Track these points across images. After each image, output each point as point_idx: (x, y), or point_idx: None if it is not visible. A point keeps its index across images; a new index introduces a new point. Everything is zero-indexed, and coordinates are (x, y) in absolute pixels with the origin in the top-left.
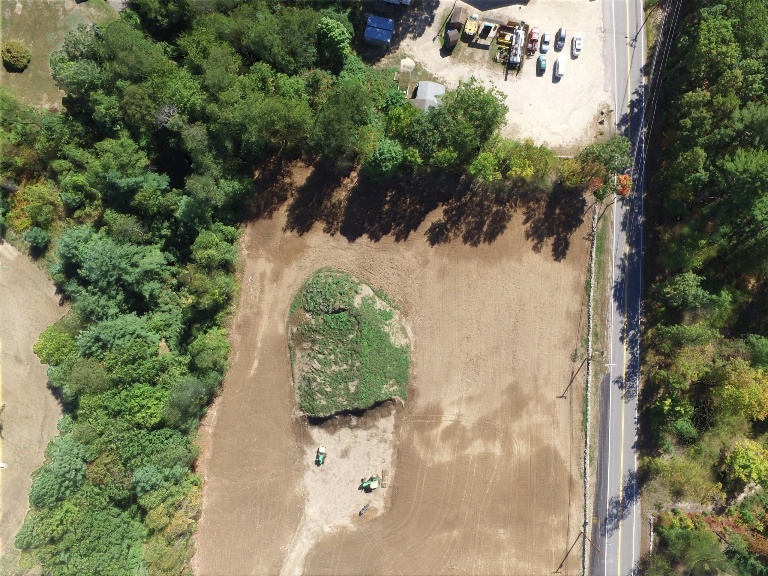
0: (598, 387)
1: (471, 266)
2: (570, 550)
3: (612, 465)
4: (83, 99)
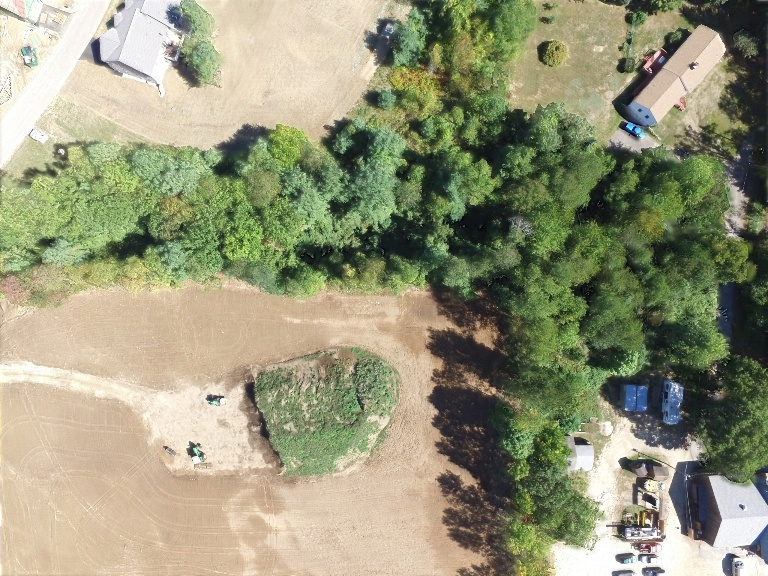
0: None
1: (423, 520)
2: None
3: None
4: (524, 134)
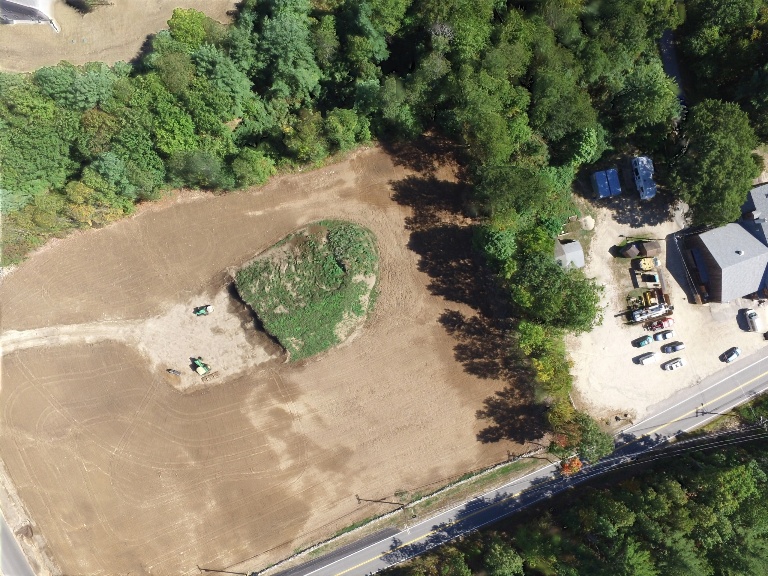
0: (383, 527)
1: (437, 364)
2: (226, 572)
3: (319, 573)
4: None
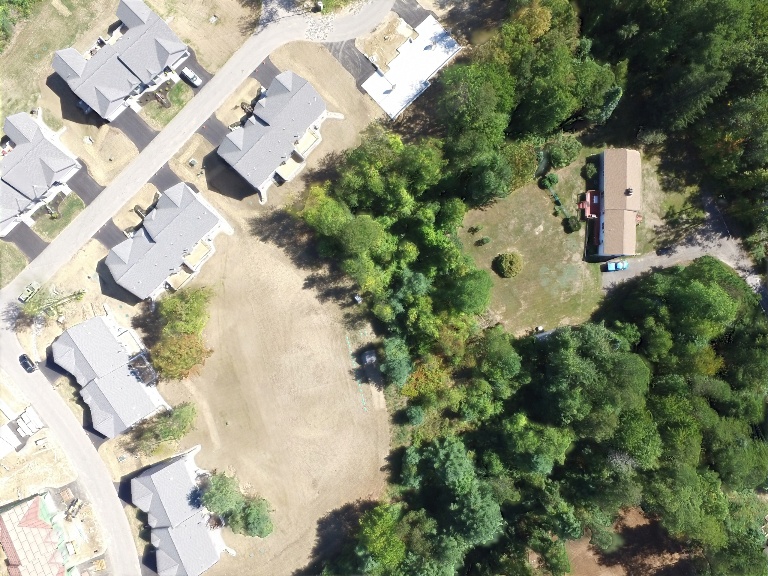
0: None
1: None
2: None
3: None
4: (553, 370)
